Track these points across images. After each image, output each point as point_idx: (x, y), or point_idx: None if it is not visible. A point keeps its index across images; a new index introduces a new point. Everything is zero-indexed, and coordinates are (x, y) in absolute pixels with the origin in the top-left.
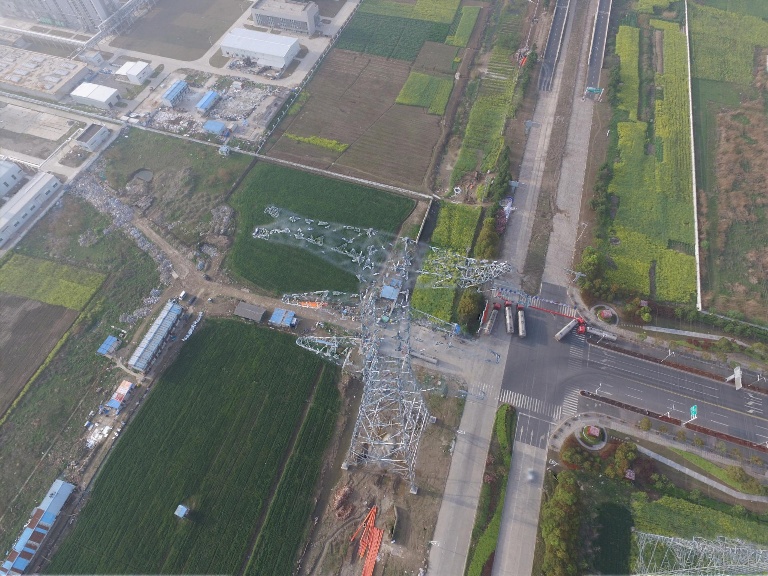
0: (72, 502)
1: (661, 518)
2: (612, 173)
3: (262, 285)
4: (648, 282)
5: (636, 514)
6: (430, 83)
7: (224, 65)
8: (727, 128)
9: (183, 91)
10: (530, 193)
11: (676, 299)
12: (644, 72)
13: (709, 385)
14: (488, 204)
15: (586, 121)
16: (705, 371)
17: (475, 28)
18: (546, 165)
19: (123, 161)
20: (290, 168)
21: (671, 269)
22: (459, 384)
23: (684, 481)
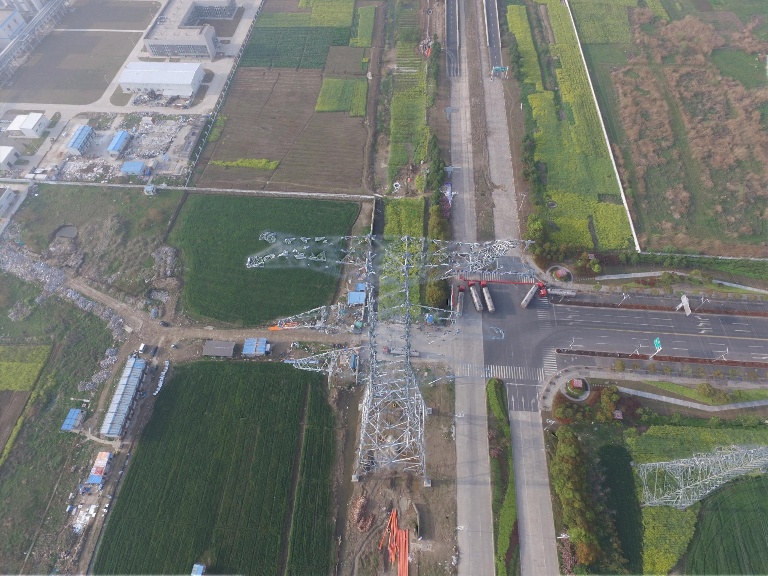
0: None
1: (653, 447)
2: (534, 143)
3: (225, 319)
4: (590, 236)
5: (631, 449)
6: (345, 87)
7: (127, 102)
8: (622, 84)
9: (89, 136)
10: (465, 175)
11: (617, 246)
12: (539, 45)
13: (663, 317)
14: (429, 193)
15: (499, 99)
16: (657, 305)
17: (375, 27)
18: (473, 146)
19: (39, 221)
20: (225, 195)
21: (606, 220)
22: (445, 370)
23: (664, 408)
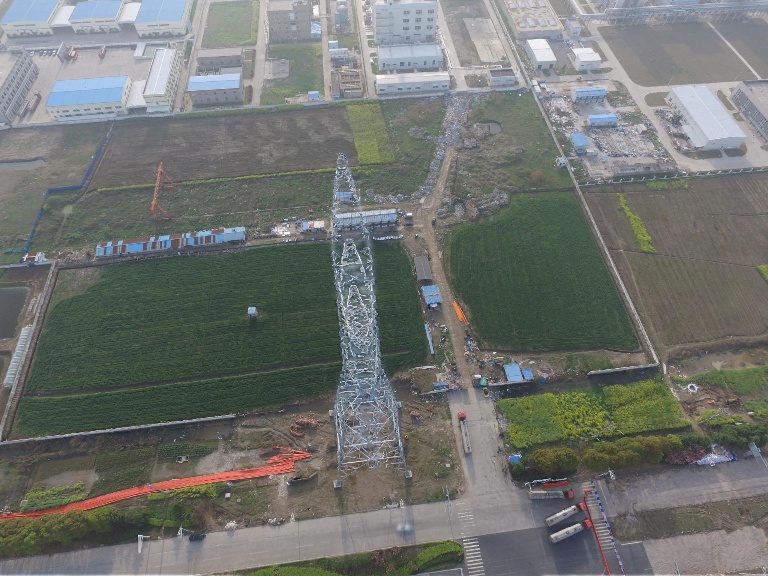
0: (235, 244)
1: None
2: None
3: (453, 264)
4: None
5: None
6: None
7: (654, 106)
8: None
9: (596, 98)
10: (764, 480)
11: None
12: None
13: None
14: (702, 431)
15: None
16: None
17: None
18: None
19: (496, 108)
20: (586, 219)
21: None
22: (458, 487)
23: None
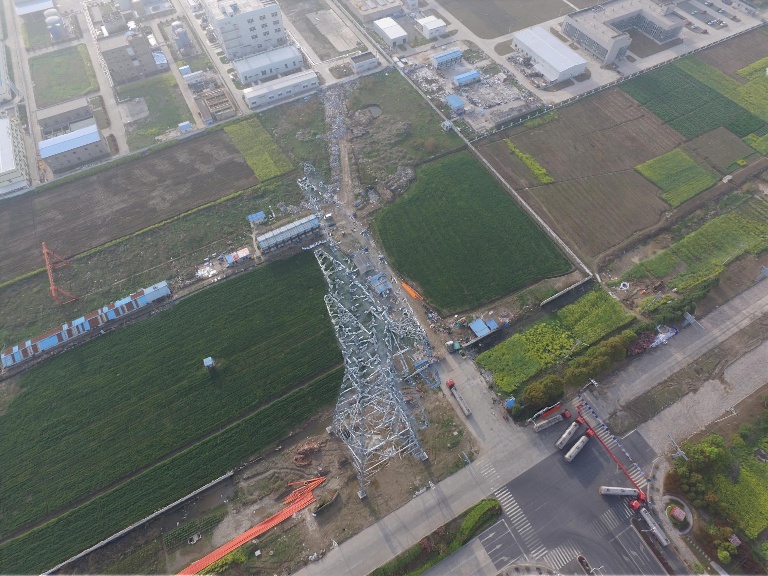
0: (162, 302)
1: None
2: None
3: (387, 248)
4: (763, 526)
5: None
6: (688, 169)
7: (505, 54)
8: None
9: (454, 60)
10: (703, 340)
11: None
12: None
13: None
14: (645, 319)
15: None
16: None
17: None
18: (750, 325)
19: (370, 92)
20: (487, 170)
21: None
22: (471, 449)
23: None
